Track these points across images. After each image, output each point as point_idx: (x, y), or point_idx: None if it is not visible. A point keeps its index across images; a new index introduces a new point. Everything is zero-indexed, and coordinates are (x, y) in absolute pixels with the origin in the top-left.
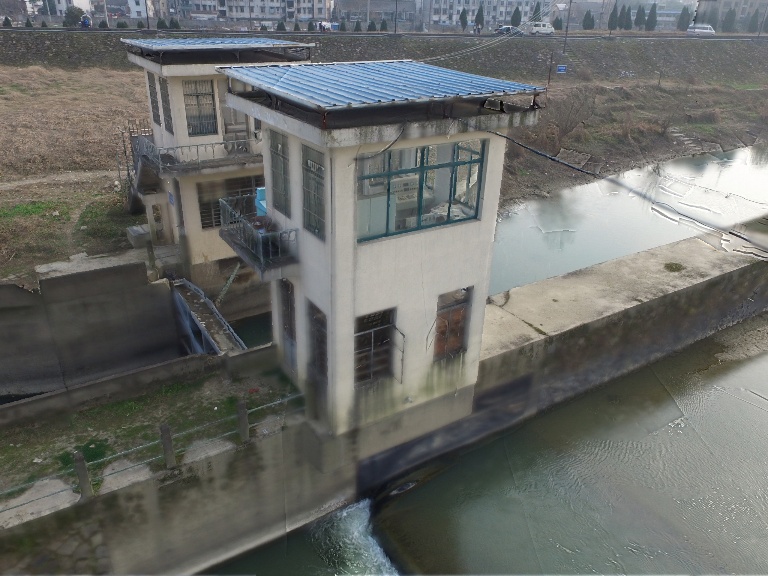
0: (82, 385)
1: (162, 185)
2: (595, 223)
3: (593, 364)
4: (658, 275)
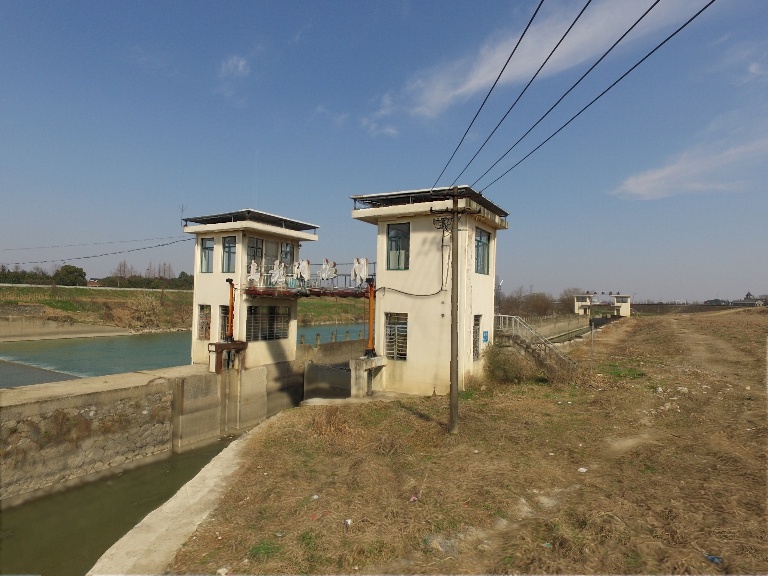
0: (348, 340)
1: None
2: None
3: None
4: None
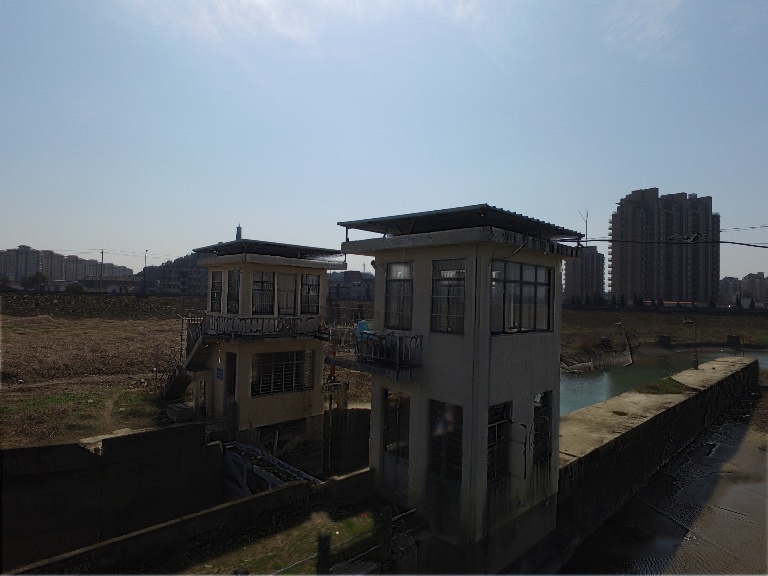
0: (197, 514)
1: (208, 365)
2: None
3: (604, 490)
4: (614, 418)
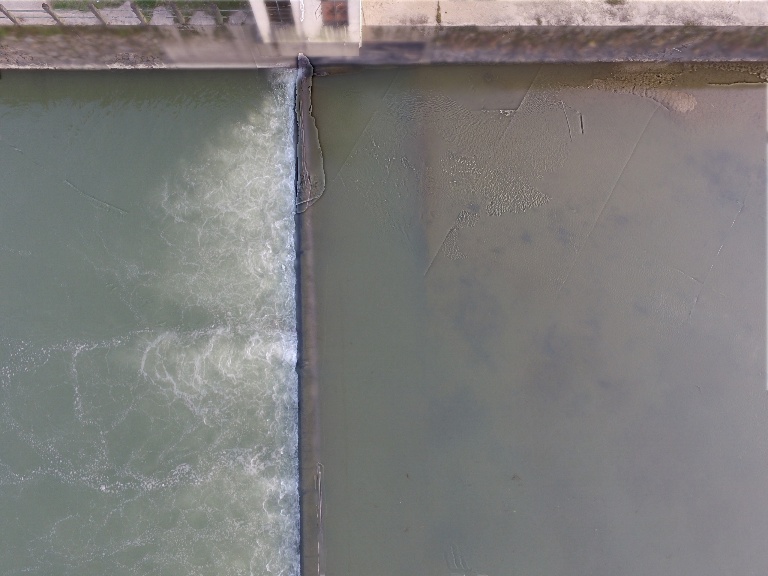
0: None
1: None
2: None
3: (483, 50)
4: (590, 1)
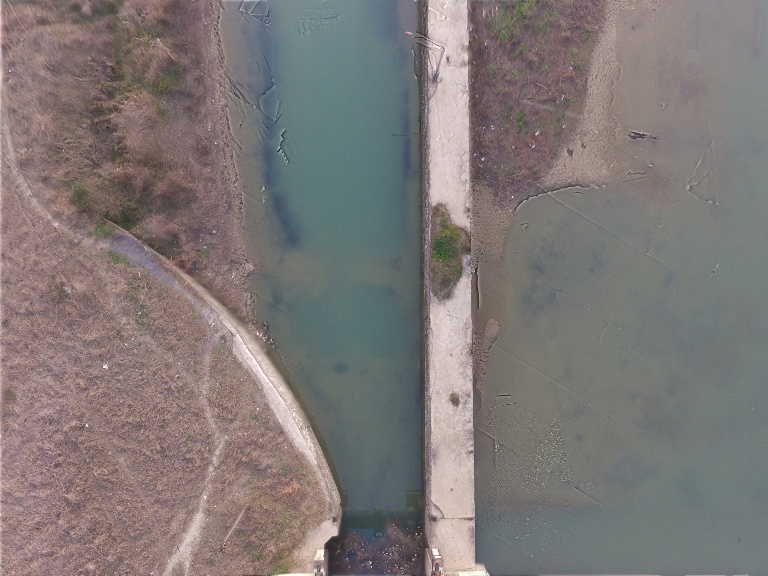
0: None
1: None
2: (310, 274)
3: None
4: (457, 417)
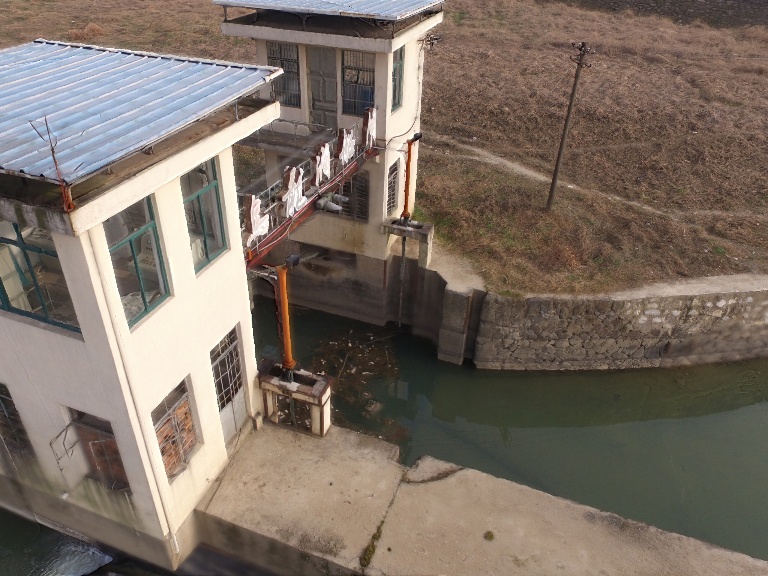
0: None
1: None
2: None
3: None
4: None
